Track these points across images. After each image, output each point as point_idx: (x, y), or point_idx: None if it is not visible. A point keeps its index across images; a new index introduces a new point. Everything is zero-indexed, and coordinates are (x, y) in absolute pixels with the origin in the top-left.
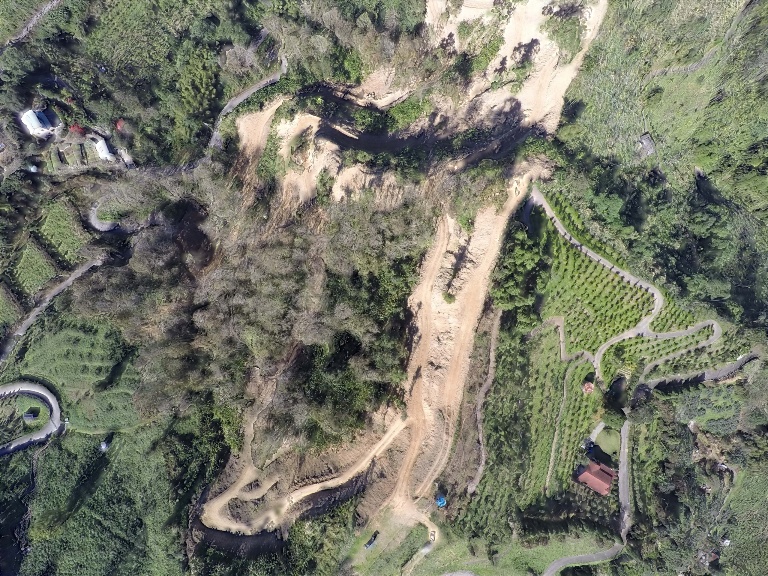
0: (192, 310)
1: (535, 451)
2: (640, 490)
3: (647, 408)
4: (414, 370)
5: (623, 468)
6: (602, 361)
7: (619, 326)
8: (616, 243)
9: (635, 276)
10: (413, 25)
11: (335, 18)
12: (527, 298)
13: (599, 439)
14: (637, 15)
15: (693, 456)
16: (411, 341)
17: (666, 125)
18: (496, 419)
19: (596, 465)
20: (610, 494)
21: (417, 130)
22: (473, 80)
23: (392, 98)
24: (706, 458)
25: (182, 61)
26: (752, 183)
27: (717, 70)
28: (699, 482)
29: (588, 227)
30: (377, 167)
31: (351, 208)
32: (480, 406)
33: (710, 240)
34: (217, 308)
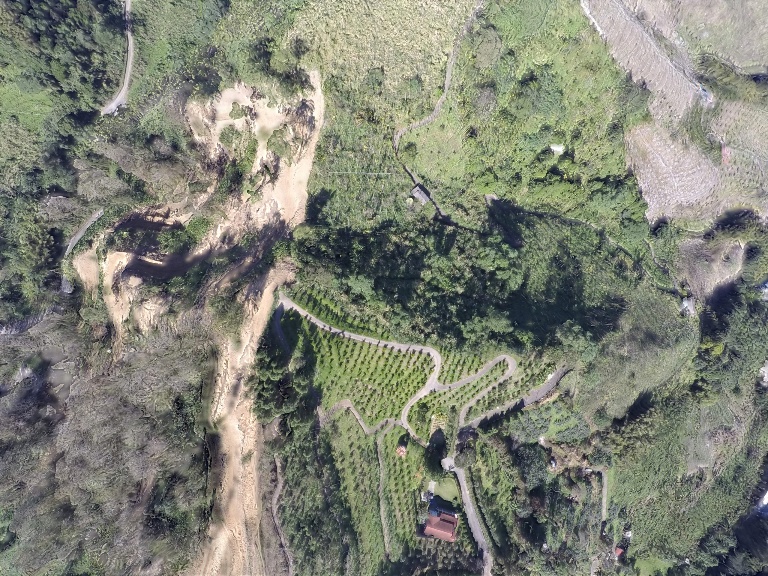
0: (56, 461)
1: (360, 527)
2: (498, 522)
3: (468, 452)
4: (210, 494)
5: (469, 509)
6: (410, 422)
7: (409, 389)
8: (378, 318)
9: (404, 343)
10: (184, 145)
11: (119, 155)
12: (281, 408)
13: (437, 489)
14: (355, 95)
15: (550, 471)
16: (207, 465)
17: (435, 171)
18: (298, 517)
19: (434, 518)
20: (459, 539)
21: (208, 243)
22: (243, 184)
23: (189, 213)
24: (568, 467)
25: (18, 219)
26: (545, 193)
27: (454, 116)
28: (564, 494)
29: (347, 311)
30: (160, 301)
31: (126, 357)
32: (275, 512)
33: (495, 272)
34: (64, 461)
